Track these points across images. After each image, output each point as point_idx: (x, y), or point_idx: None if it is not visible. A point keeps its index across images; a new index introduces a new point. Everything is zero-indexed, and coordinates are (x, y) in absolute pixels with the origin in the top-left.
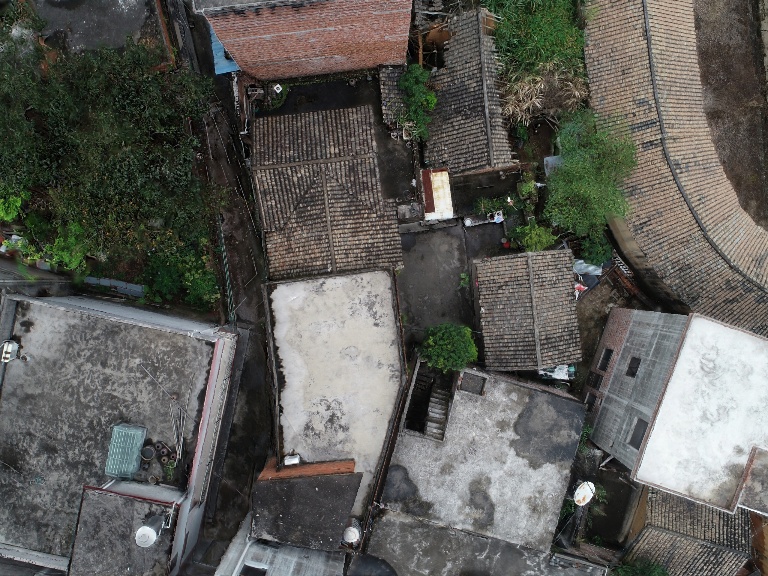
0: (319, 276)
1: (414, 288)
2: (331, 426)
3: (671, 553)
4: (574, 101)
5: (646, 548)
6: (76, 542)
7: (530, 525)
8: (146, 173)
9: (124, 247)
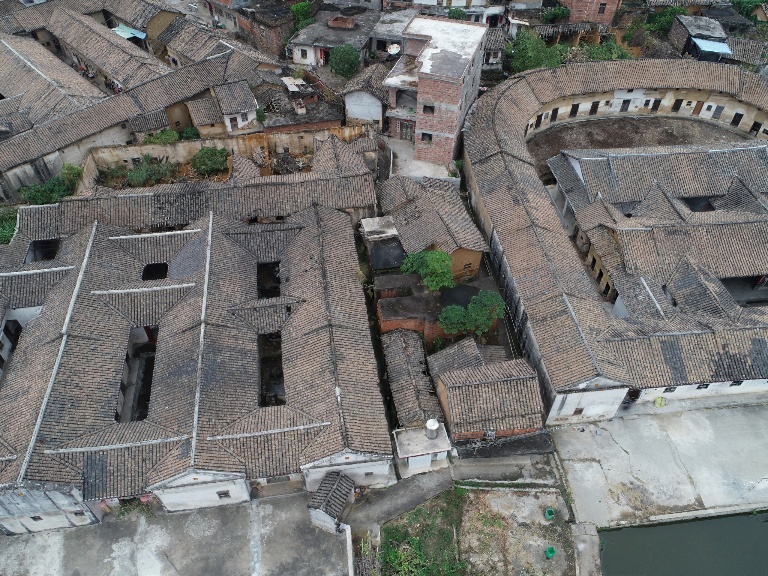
0: None
1: None
2: None
3: None
4: None
5: None
6: None
7: None
8: None
9: None
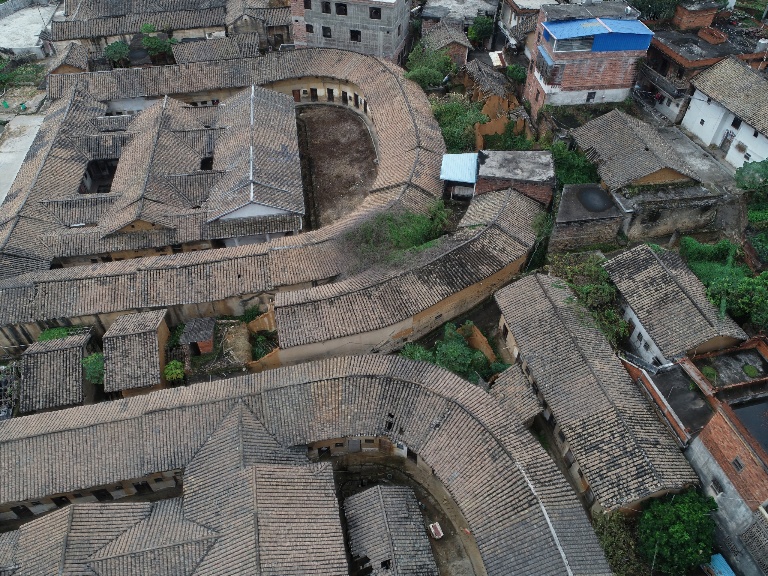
0: None
1: None
2: None
3: None
4: None
5: None
6: None
7: None
8: (626, 0)
9: None
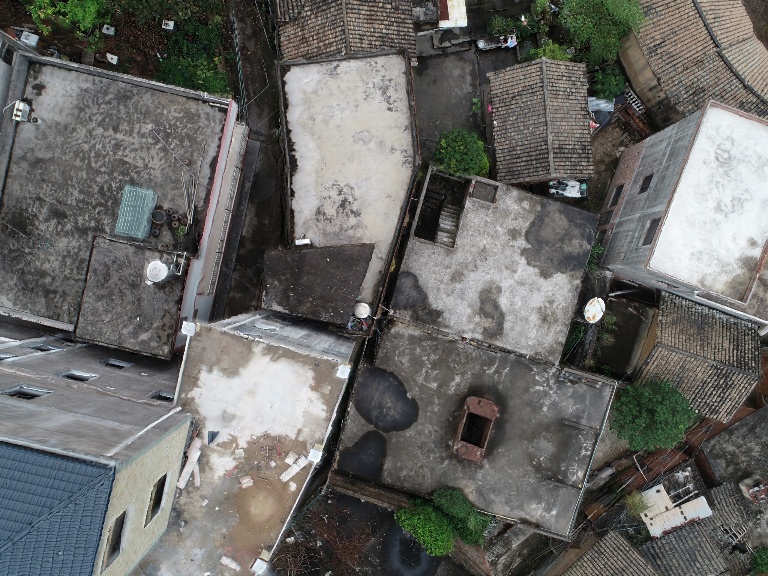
0: (333, 59)
1: (426, 112)
2: (343, 211)
3: (680, 377)
4: None
5: (655, 371)
6: (86, 291)
7: (540, 335)
8: None
9: (139, 1)
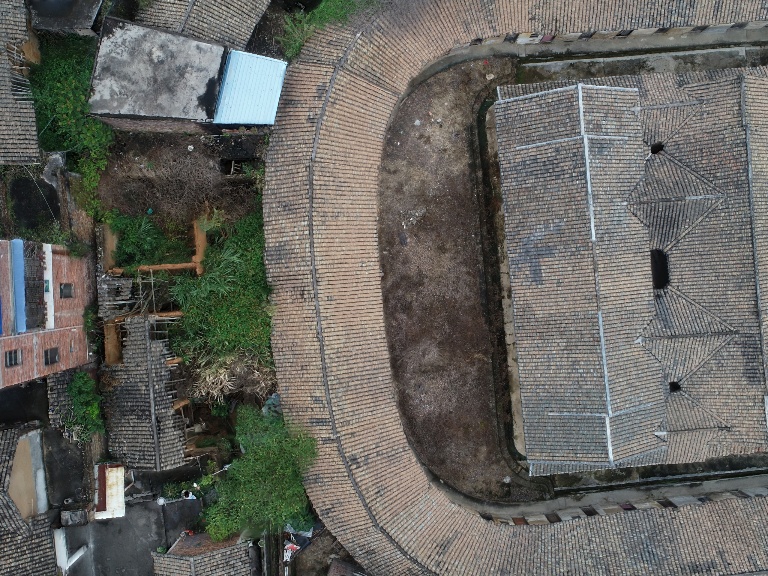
0: None
1: (111, 561)
2: None
3: None
4: (263, 386)
5: None
6: None
7: None
8: None
9: None
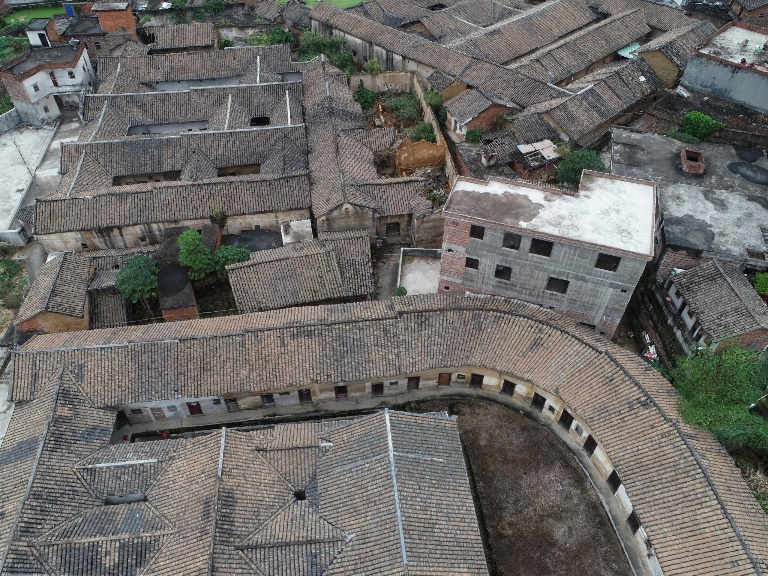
0: None
1: None
2: None
3: None
4: None
5: None
6: None
7: (677, 191)
8: None
9: None
